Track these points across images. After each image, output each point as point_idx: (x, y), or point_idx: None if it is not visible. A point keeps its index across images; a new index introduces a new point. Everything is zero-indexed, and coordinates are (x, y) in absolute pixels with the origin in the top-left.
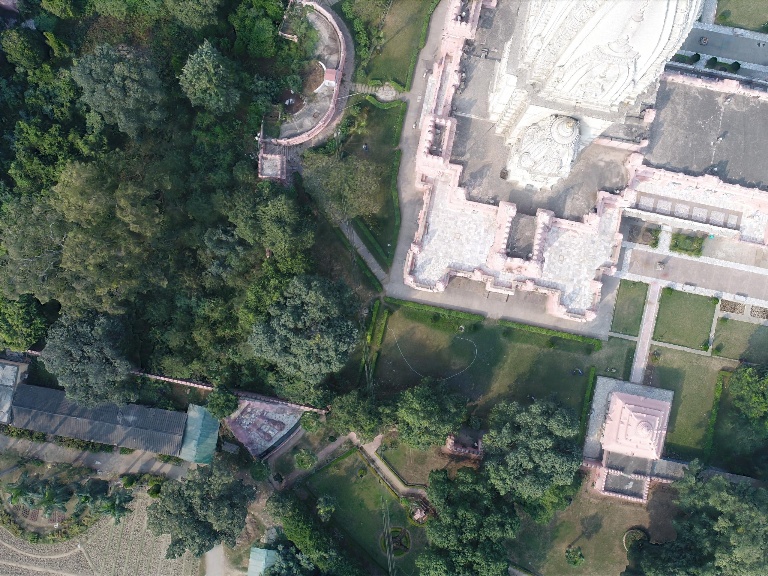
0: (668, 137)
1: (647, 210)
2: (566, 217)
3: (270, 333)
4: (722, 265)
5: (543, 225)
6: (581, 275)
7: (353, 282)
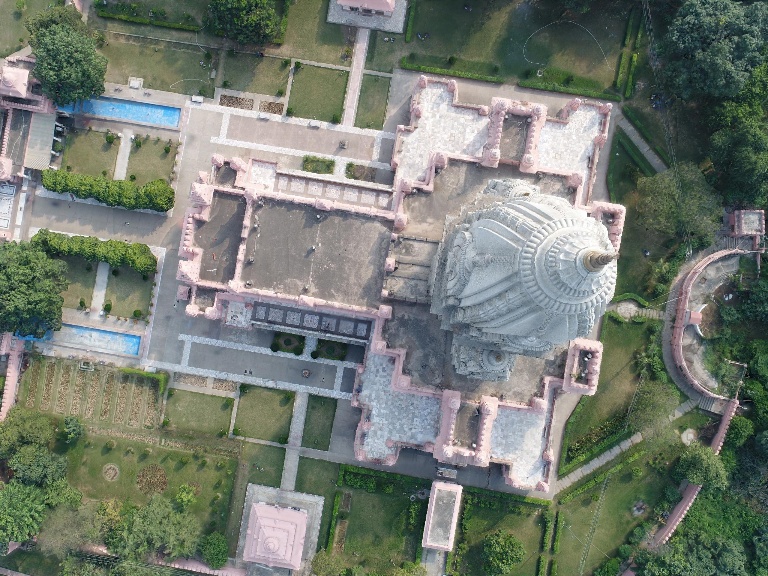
0: (365, 250)
1: (368, 191)
2: (465, 165)
3: (766, 30)
4: (283, 149)
5: (498, 146)
6: (433, 122)
7: (653, 115)
